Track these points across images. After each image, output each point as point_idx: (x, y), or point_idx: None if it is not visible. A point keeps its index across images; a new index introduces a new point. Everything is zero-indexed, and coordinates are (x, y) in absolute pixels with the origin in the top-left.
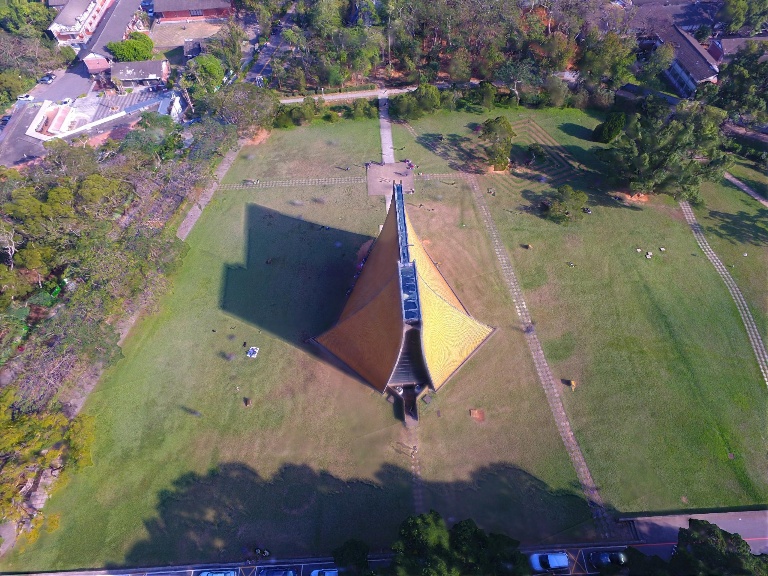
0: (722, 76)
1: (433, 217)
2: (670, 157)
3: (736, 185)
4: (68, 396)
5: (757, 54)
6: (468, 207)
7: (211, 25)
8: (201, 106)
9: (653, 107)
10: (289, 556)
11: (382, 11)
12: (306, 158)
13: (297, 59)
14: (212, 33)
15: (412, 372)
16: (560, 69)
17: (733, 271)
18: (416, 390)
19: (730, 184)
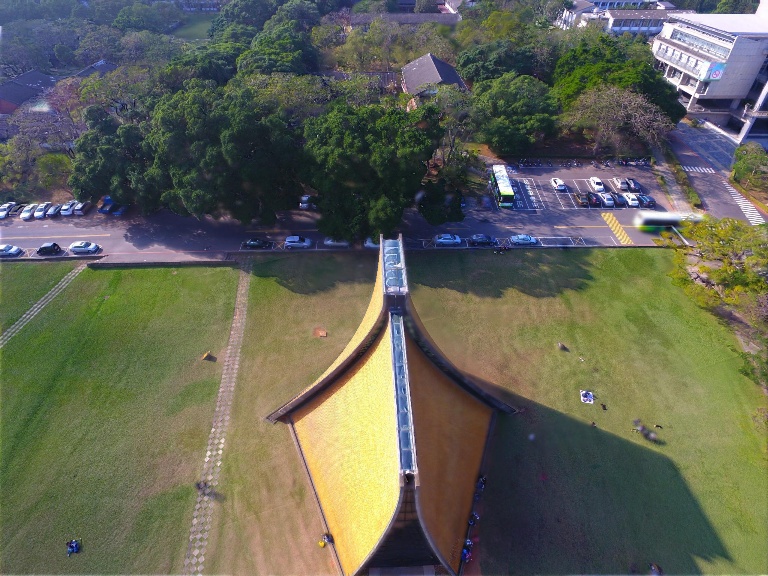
0: None
1: None
2: None
3: None
4: None
5: None
6: None
7: None
8: None
9: None
10: (479, 251)
11: None
12: None
13: None
14: None
15: None
16: None
17: None
18: None
19: None
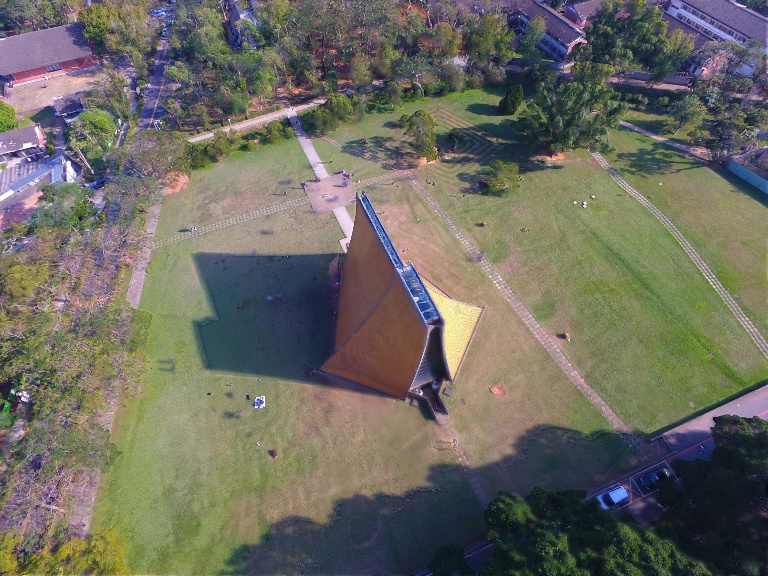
0: (591, 36)
1: (387, 219)
2: (579, 115)
3: (628, 127)
4: (79, 516)
5: (613, 12)
6: (415, 202)
7: (75, 77)
8: (99, 165)
9: (542, 74)
10: None
11: (265, 31)
12: (237, 193)
13: (188, 95)
14: (79, 86)
15: (429, 370)
16: (452, 56)
17: (654, 201)
18: (435, 387)
19: (623, 128)
